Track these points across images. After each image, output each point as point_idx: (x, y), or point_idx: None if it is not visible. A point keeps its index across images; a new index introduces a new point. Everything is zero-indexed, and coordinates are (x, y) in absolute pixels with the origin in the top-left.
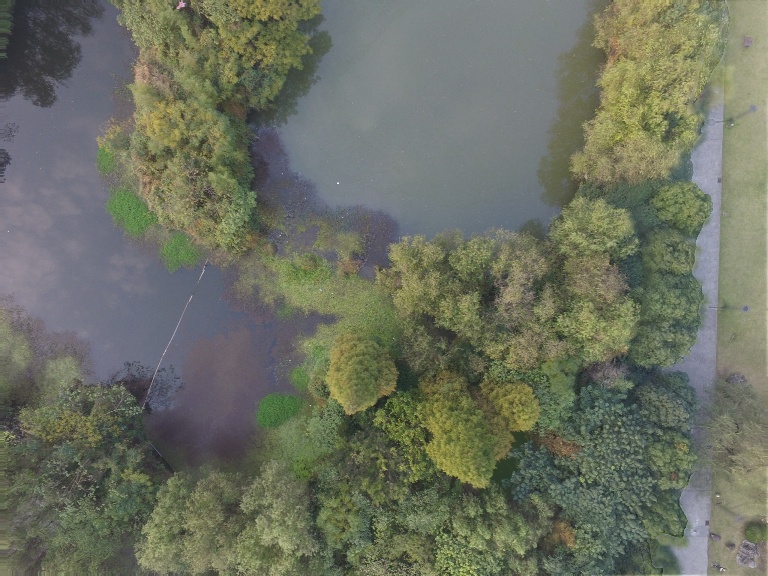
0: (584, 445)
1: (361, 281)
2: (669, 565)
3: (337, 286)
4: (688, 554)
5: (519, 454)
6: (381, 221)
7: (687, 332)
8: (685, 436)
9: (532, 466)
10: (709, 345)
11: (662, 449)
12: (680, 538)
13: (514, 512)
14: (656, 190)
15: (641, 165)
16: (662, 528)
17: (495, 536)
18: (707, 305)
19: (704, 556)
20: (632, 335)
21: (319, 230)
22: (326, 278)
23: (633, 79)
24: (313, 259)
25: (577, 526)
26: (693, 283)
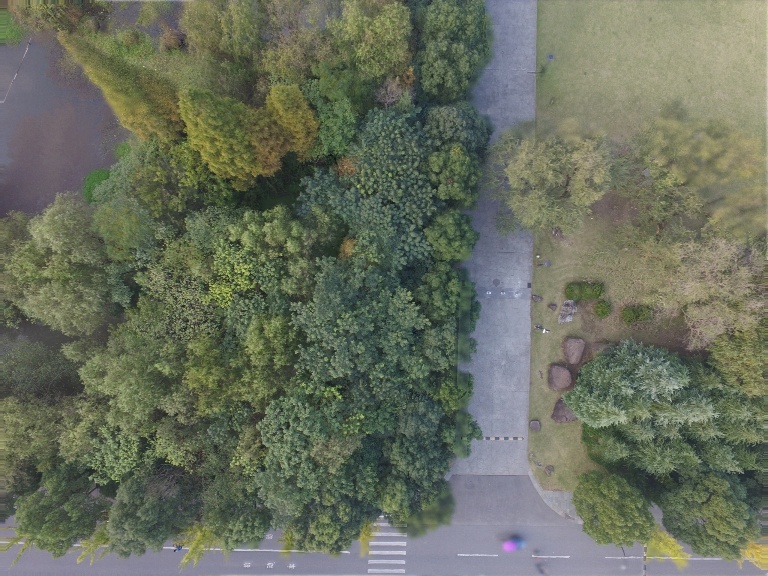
0: (362, 154)
1: (184, 57)
2: (492, 328)
3: (160, 62)
4: (511, 317)
5: (308, 178)
6: None
7: (465, 45)
8: (462, 143)
9: (318, 186)
10: (528, 110)
11: (438, 155)
12: (502, 300)
13: (293, 221)
14: None
15: None
16: (440, 233)
17: (267, 236)
18: (525, 70)
19: (527, 318)
20: (412, 51)
21: (141, 7)
22: (149, 54)
23: None
24: (135, 35)
25: (357, 235)
26: None
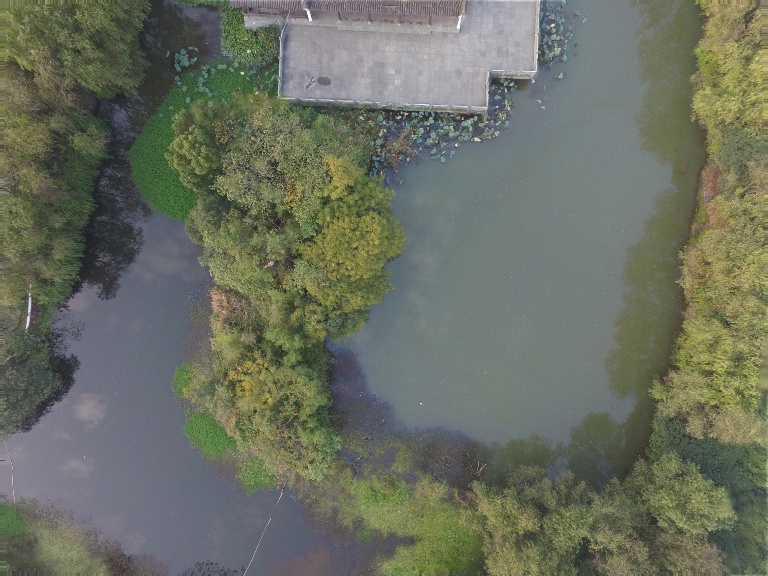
0: None
1: (440, 503)
2: None
3: (416, 508)
4: None
5: None
6: (460, 443)
7: None
8: None
9: None
10: None
11: None
12: None
13: None
14: (752, 457)
15: (738, 436)
16: None
17: None
18: None
19: None
20: None
21: (397, 452)
22: (405, 500)
23: (731, 350)
24: (392, 482)
25: None
26: None
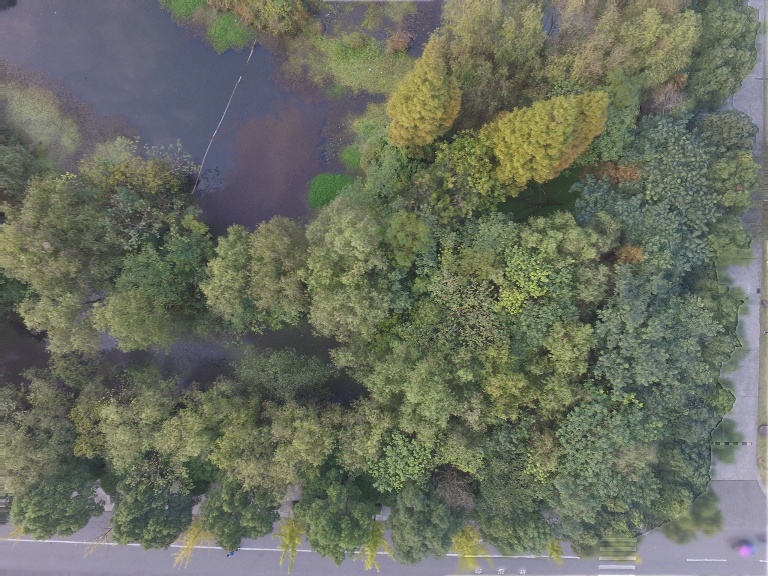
0: (650, 160)
1: (410, 60)
2: None
3: (386, 65)
4: (741, 322)
5: (582, 184)
6: None
7: None
8: (749, 149)
9: (596, 191)
10: (756, 116)
11: (727, 161)
12: None
13: (582, 226)
14: None
15: None
16: (729, 239)
17: (566, 242)
18: (753, 77)
19: (756, 324)
20: (693, 57)
21: (367, 9)
22: (375, 57)
23: None
24: (362, 38)
25: (644, 241)
26: (751, 8)
